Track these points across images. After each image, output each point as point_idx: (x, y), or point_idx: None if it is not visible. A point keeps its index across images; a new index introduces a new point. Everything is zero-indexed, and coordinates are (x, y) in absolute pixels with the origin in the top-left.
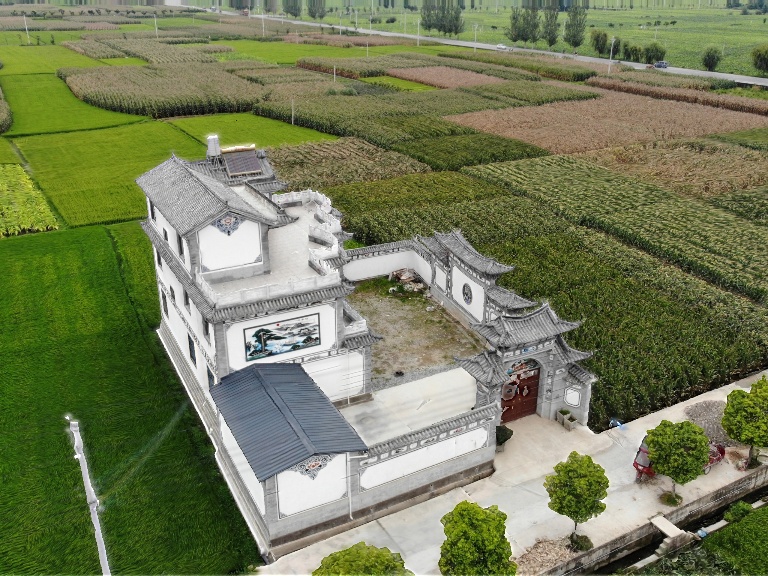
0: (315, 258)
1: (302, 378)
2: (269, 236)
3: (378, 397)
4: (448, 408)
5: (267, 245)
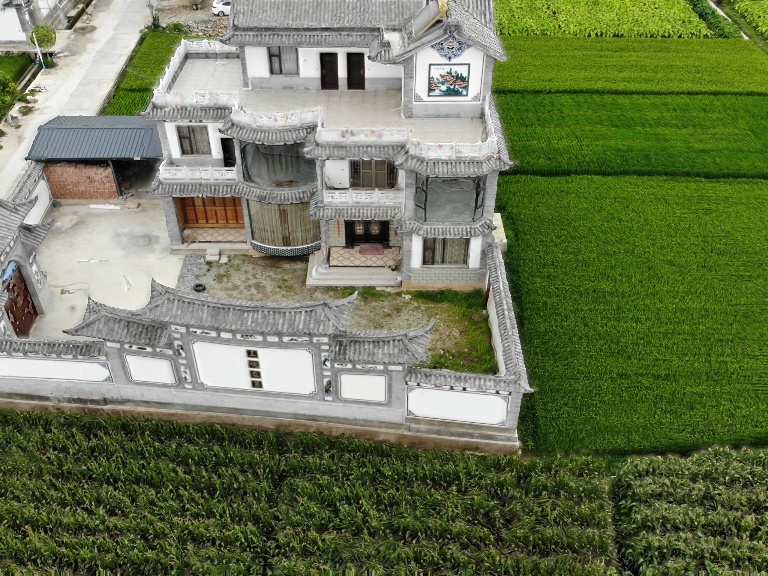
0: (222, 97)
1: (154, 152)
2: (366, 108)
3: (172, 258)
4: (101, 296)
5: (241, 56)
